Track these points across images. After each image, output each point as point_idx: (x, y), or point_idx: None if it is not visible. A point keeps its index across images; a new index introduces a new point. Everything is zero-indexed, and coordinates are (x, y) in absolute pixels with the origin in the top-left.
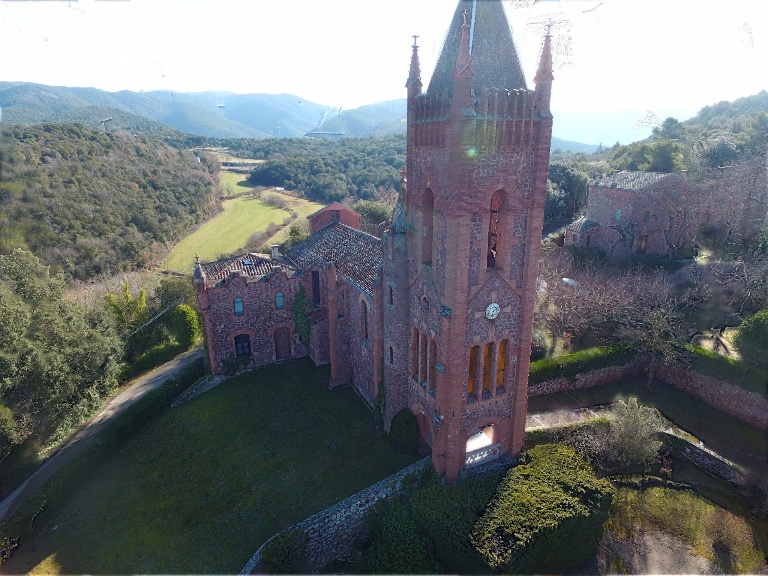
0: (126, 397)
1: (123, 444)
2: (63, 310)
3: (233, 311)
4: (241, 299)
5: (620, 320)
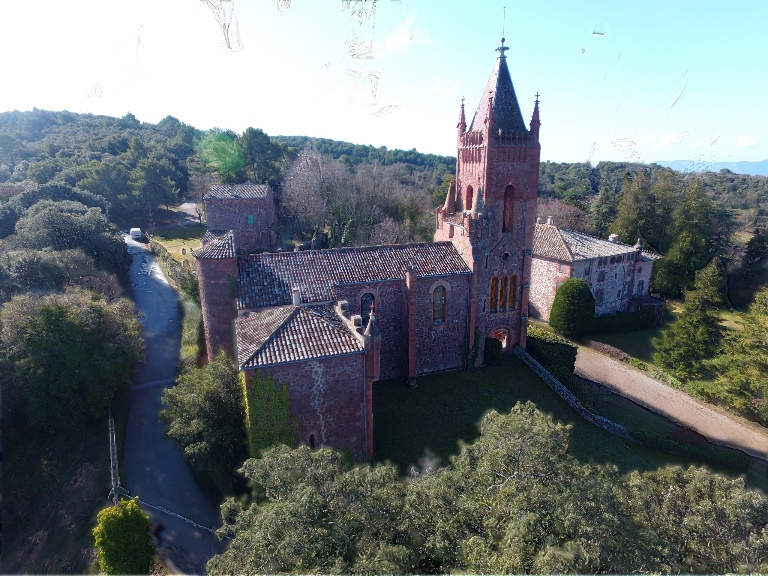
0: None
1: None
2: None
3: None
4: None
5: None
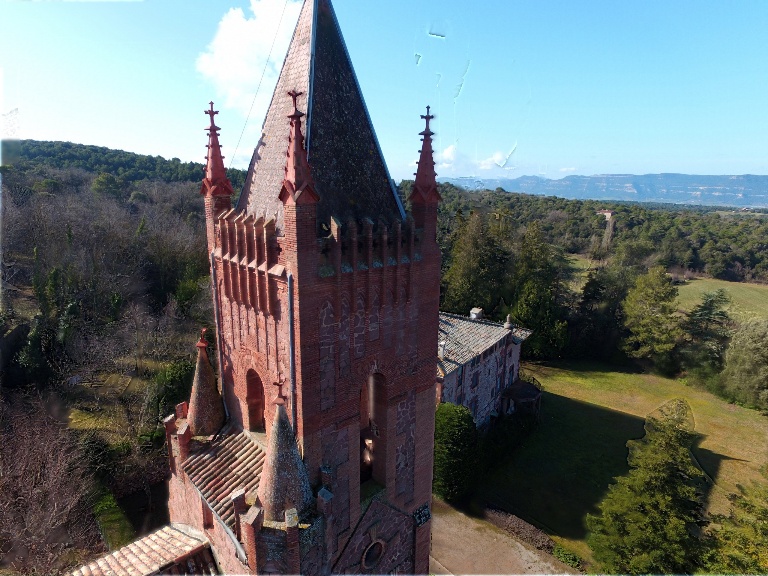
0: None
1: None
2: None
3: None
4: None
5: None
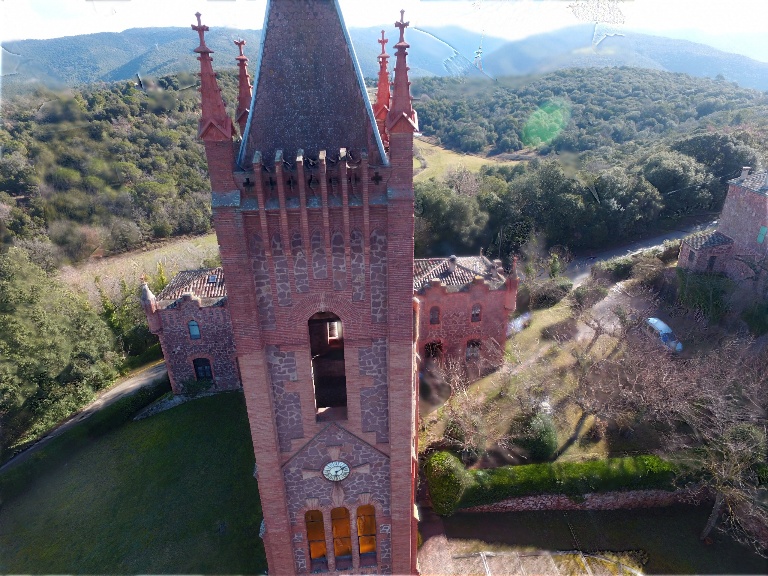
0: (116, 393)
1: (72, 456)
2: (35, 315)
3: (188, 334)
4: (196, 322)
5: None
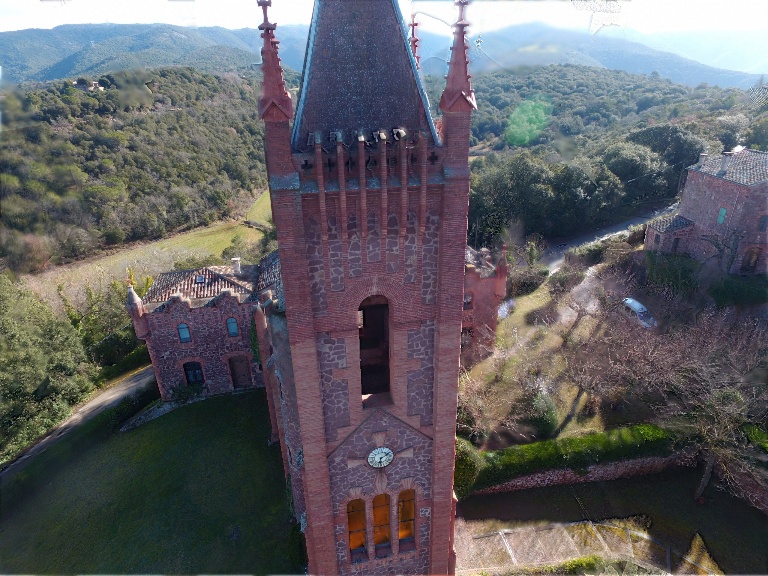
0: (95, 405)
1: (56, 474)
2: (5, 327)
3: (178, 337)
4: (186, 325)
5: (675, 391)
